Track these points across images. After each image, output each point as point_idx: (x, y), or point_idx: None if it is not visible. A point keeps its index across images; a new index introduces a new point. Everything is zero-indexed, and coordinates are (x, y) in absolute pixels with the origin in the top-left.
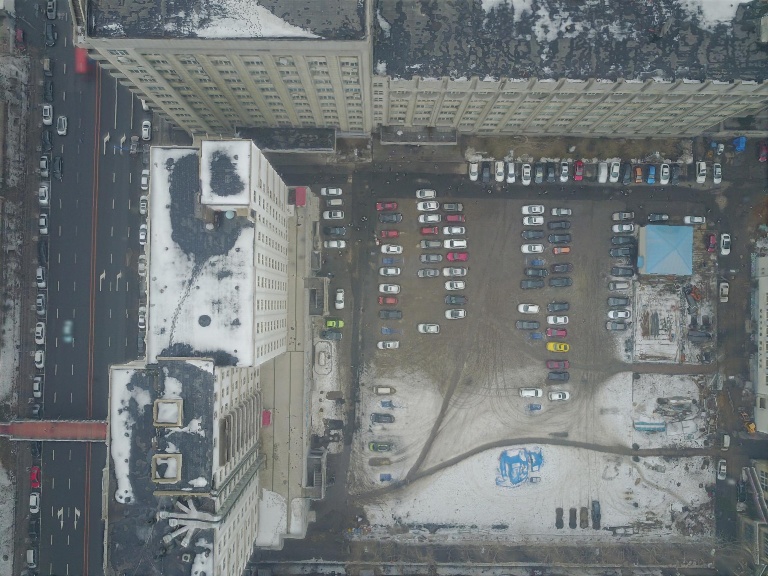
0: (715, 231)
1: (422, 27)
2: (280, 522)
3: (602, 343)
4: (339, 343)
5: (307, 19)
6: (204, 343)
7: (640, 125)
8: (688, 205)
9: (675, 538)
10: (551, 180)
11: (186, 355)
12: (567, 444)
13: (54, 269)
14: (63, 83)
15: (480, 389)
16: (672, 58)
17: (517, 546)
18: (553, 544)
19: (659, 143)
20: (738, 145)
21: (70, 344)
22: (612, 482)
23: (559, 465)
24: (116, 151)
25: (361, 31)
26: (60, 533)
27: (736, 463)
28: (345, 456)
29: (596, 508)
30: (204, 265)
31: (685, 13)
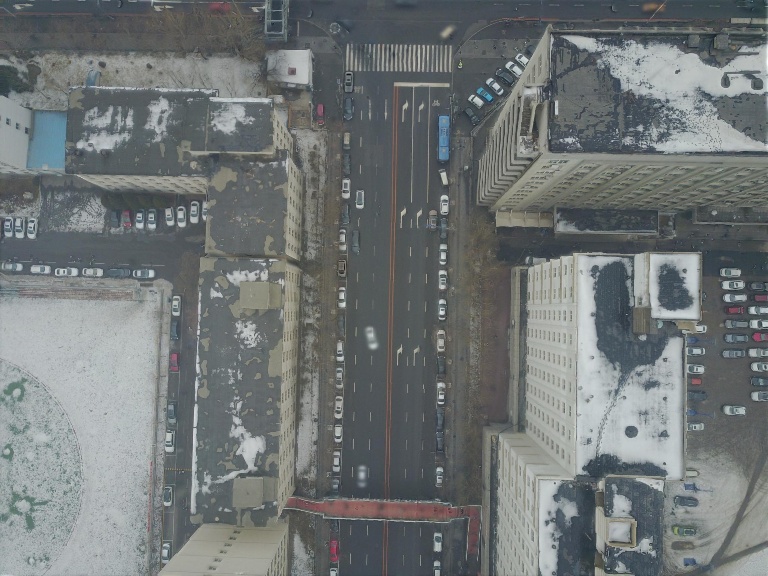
0: None
1: None
2: None
3: None
4: None
5: None
6: (632, 455)
7: None
8: None
9: None
10: None
11: (614, 467)
12: None
13: (351, 343)
14: (359, 156)
15: None
16: None
17: None
18: None
19: None
20: None
21: (367, 418)
22: None
23: None
24: (412, 225)
25: None
26: None
27: None
28: None
29: None
30: (630, 375)
31: None
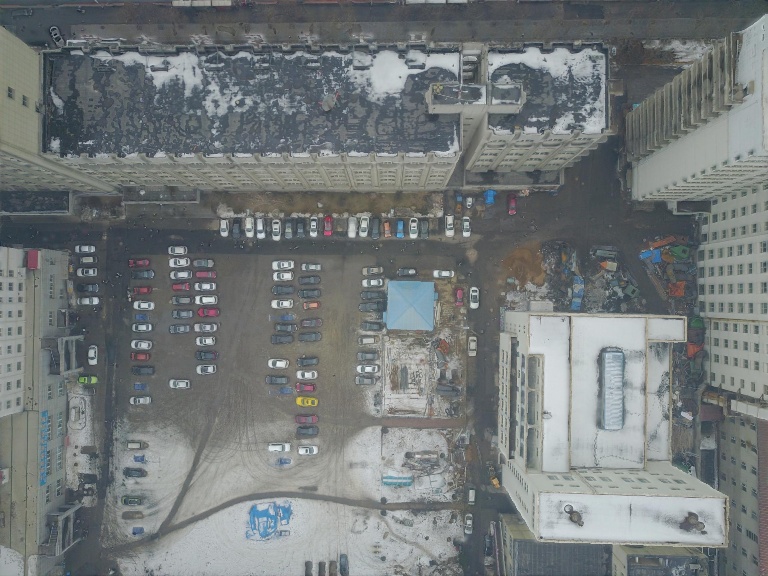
0: (465, 285)
1: (95, 103)
2: None
3: (352, 397)
4: (93, 398)
5: None
6: None
7: (373, 183)
8: (438, 259)
9: None
10: (301, 235)
11: None
12: (317, 498)
13: None
14: None
15: (231, 443)
16: (341, 131)
17: None
18: None
19: (410, 197)
20: (486, 198)
21: None
22: (361, 536)
23: (309, 519)
24: None
25: None
26: None
27: (484, 517)
28: (99, 510)
29: (343, 562)
30: None
31: (354, 85)
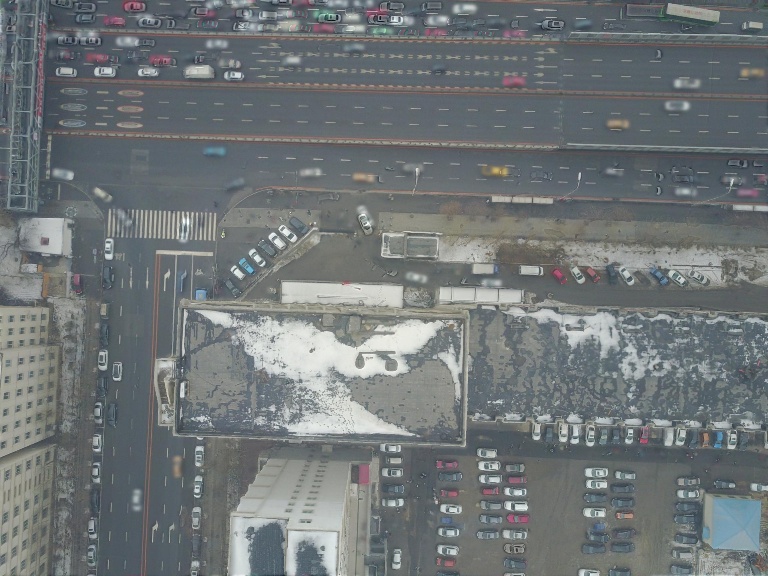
0: None
1: (506, 361)
2: None
3: None
4: None
5: (402, 416)
6: None
7: None
8: (755, 470)
9: None
10: (616, 442)
11: None
12: None
13: (106, 518)
14: (119, 326)
15: None
16: (762, 400)
17: None
18: None
19: None
20: None
21: None
22: None
23: None
24: None
25: (457, 429)
26: None
27: None
28: None
29: None
30: None
31: None
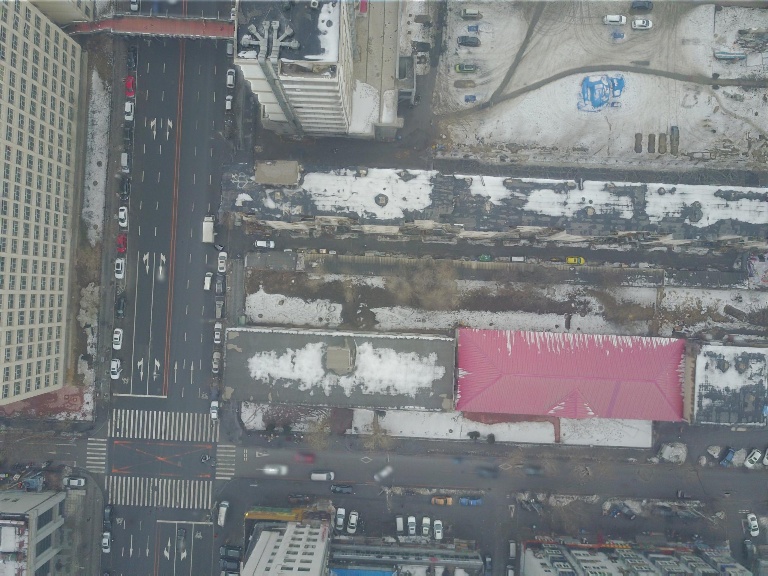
0: None
1: None
2: (372, 112)
3: None
4: None
5: None
6: None
7: None
8: None
9: (751, 165)
10: None
11: None
12: (648, 72)
13: None
14: None
15: (565, 17)
16: None
17: (596, 169)
18: (631, 167)
19: None
20: None
21: None
22: (691, 110)
23: (640, 92)
24: None
25: None
26: (153, 143)
27: None
28: (431, 77)
29: (675, 131)
30: None
31: None
